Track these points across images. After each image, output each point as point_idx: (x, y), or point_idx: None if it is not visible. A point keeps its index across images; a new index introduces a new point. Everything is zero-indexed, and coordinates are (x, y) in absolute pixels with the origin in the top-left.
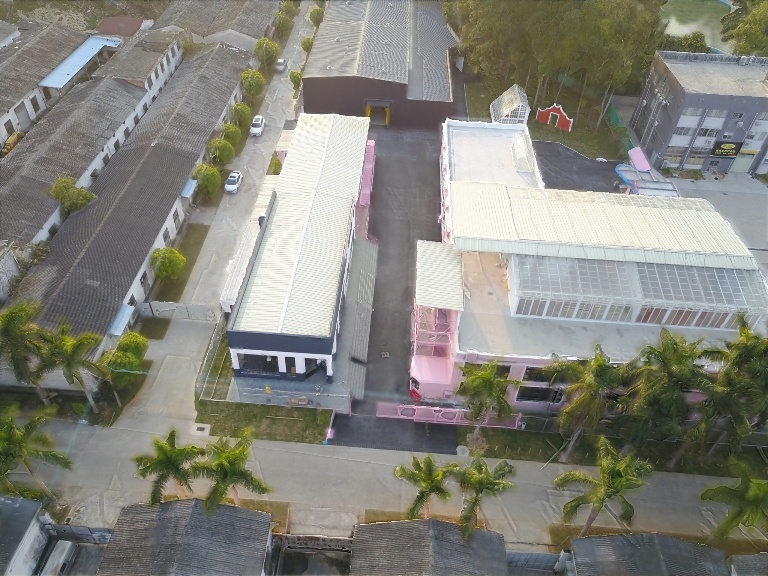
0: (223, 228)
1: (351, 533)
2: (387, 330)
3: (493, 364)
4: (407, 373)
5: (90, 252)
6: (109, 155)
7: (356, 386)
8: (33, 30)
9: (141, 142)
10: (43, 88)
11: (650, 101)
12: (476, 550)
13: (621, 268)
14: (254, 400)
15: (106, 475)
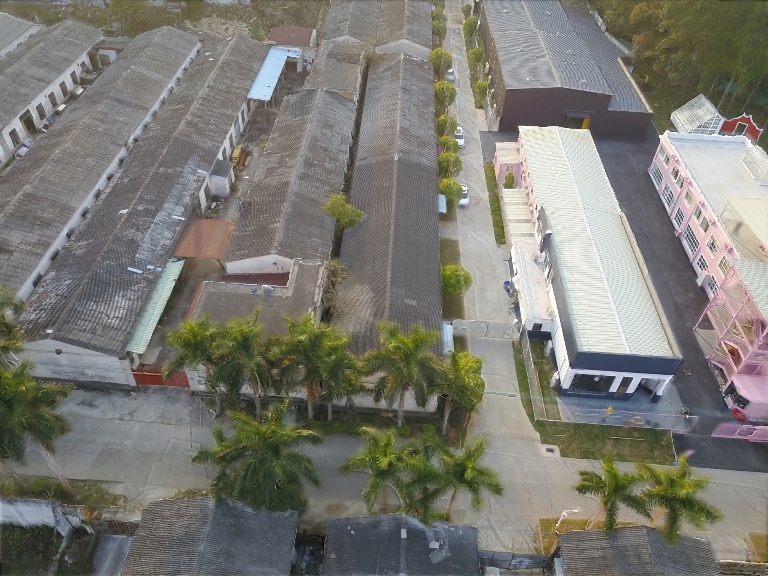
0: (472, 243)
1: (746, 557)
2: None
3: None
4: (718, 391)
5: (395, 270)
6: (345, 169)
7: (678, 405)
8: (216, 41)
9: (379, 156)
10: (248, 100)
11: None
12: None
13: None
14: (590, 420)
15: (483, 498)
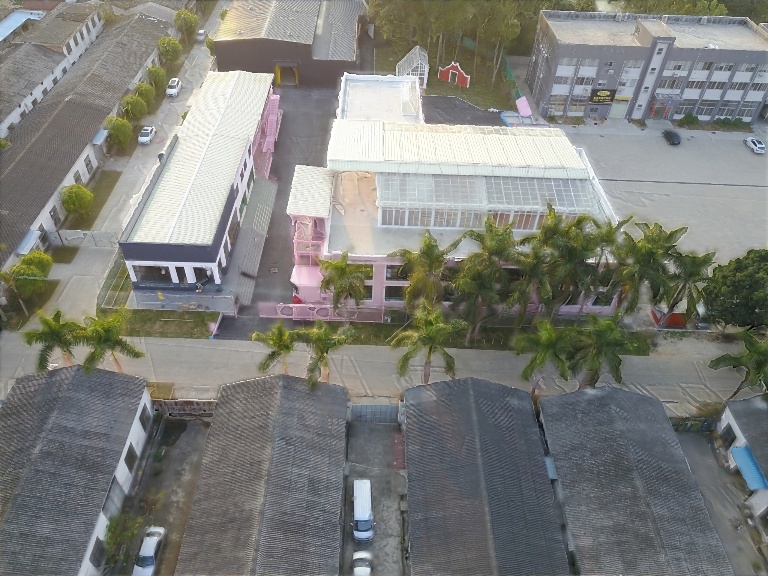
0: (134, 173)
1: None
2: (278, 251)
3: (344, 254)
4: (292, 284)
5: (0, 187)
6: (27, 112)
7: (244, 294)
8: None
9: (56, 98)
10: None
11: (538, 57)
12: (320, 397)
13: (471, 181)
14: (150, 307)
15: (11, 367)
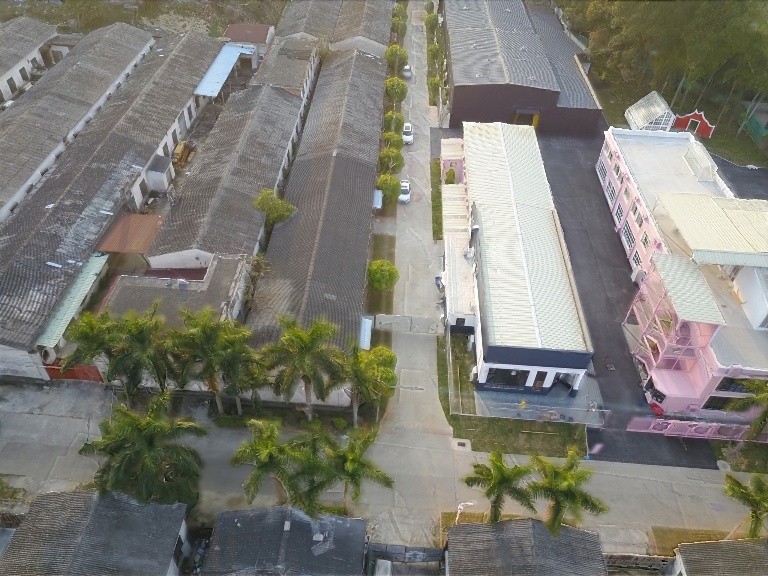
0: (409, 238)
1: (646, 550)
2: (603, 342)
3: None
4: (639, 386)
5: (318, 265)
6: (285, 165)
7: (596, 400)
8: (169, 38)
9: (318, 152)
10: (196, 97)
11: None
12: None
13: None
14: (505, 414)
15: (388, 492)
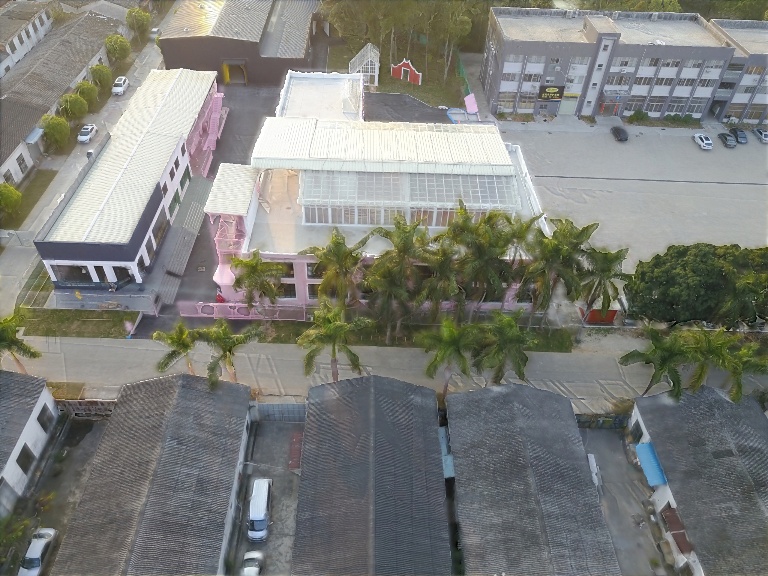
0: (70, 172)
1: None
2: (208, 250)
3: (255, 252)
4: None
5: None
6: None
7: (167, 293)
8: None
9: None
10: None
11: (488, 54)
12: (220, 396)
13: (395, 178)
14: (69, 306)
15: None
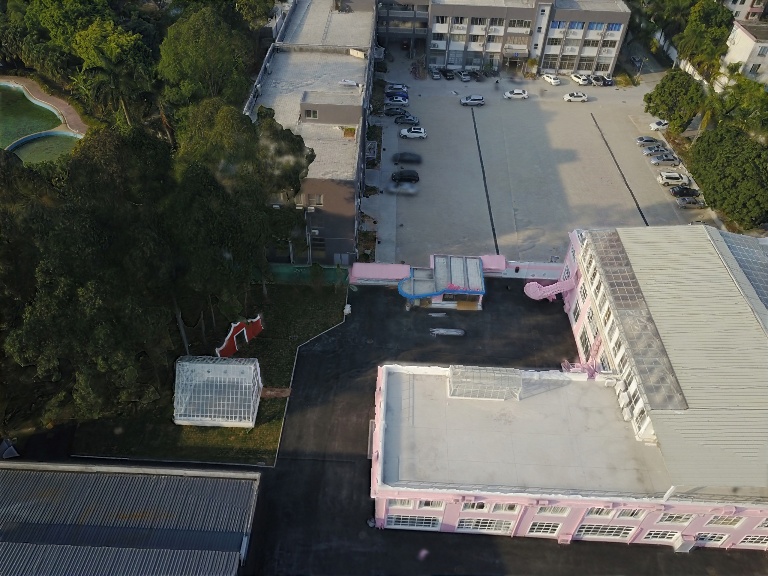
0: None
1: None
2: None
3: None
4: None
5: None
6: None
7: None
8: None
9: None
10: None
11: None
12: None
13: None
14: None
15: None
